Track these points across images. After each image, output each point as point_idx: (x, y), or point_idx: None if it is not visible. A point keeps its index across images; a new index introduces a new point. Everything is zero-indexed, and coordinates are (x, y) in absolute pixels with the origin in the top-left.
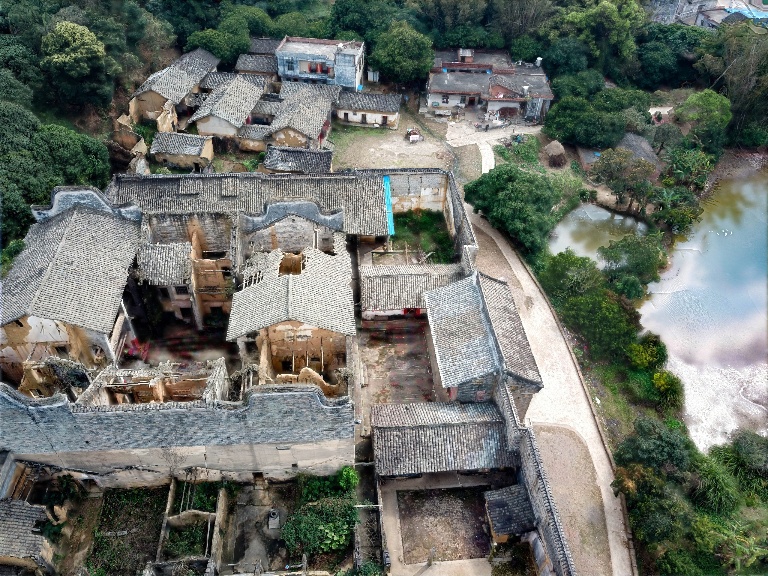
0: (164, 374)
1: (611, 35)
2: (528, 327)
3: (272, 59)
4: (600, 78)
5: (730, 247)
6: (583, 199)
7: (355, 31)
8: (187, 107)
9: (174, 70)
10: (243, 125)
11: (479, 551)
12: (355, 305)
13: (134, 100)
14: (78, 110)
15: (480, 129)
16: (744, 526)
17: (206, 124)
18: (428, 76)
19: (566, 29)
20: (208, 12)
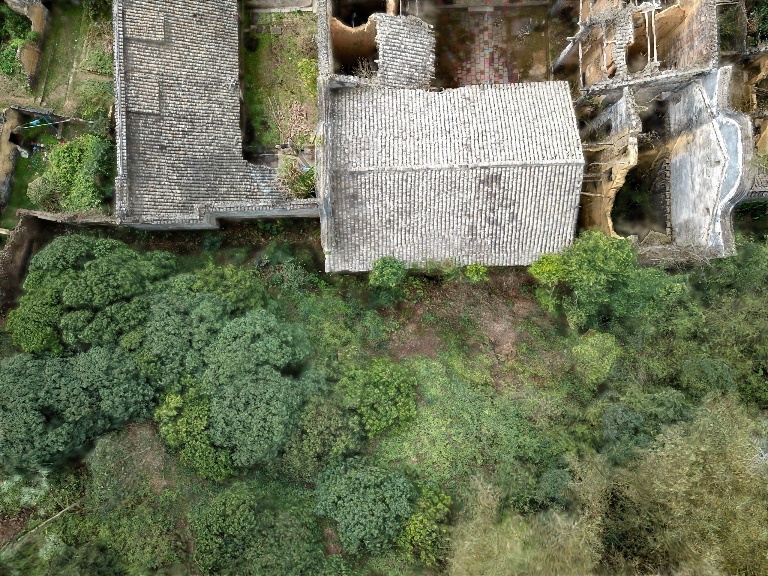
0: (625, 6)
1: None
2: None
3: None
4: None
5: None
6: None
7: None
8: None
9: None
10: None
11: None
12: None
13: None
14: None
15: None
16: None
17: None
18: None
19: None
20: None
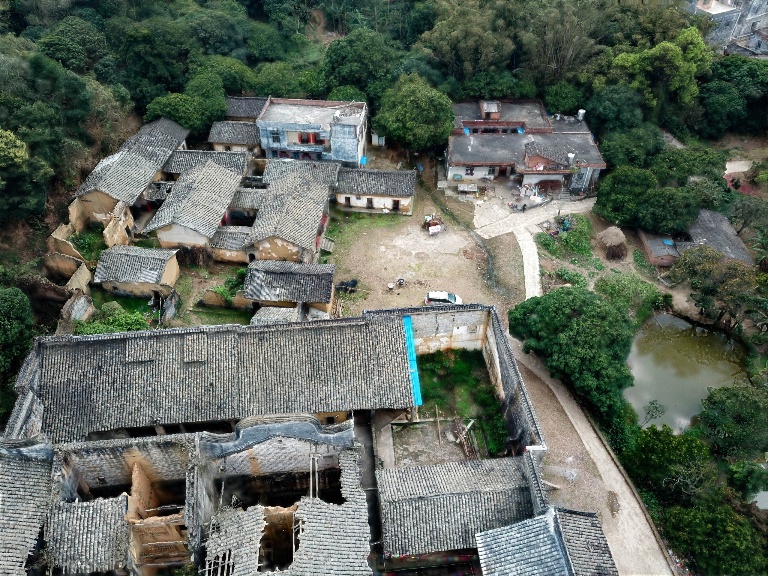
0: None
1: (672, 81)
2: (618, 551)
3: (253, 127)
4: (659, 135)
5: None
6: (655, 307)
7: (354, 83)
8: (147, 201)
9: (128, 156)
10: (216, 230)
11: None
12: (373, 527)
13: (76, 202)
14: (2, 222)
15: (515, 210)
16: None
17: (168, 232)
18: (447, 141)
19: (615, 75)
20: (173, 69)
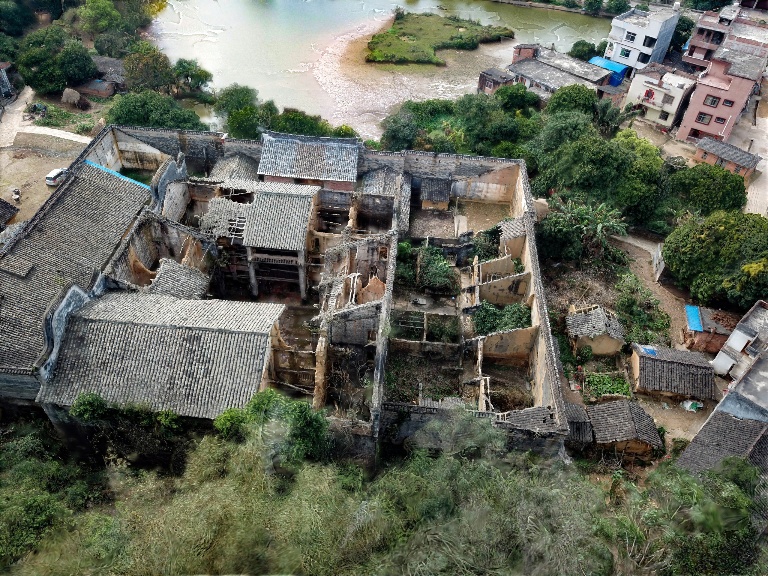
0: None
1: None
2: None
3: None
4: (4, 35)
5: (231, 78)
6: None
7: None
8: None
9: None
10: None
11: (449, 219)
12: None
13: None
14: None
15: None
16: (444, 134)
17: None
18: None
19: None
20: None
